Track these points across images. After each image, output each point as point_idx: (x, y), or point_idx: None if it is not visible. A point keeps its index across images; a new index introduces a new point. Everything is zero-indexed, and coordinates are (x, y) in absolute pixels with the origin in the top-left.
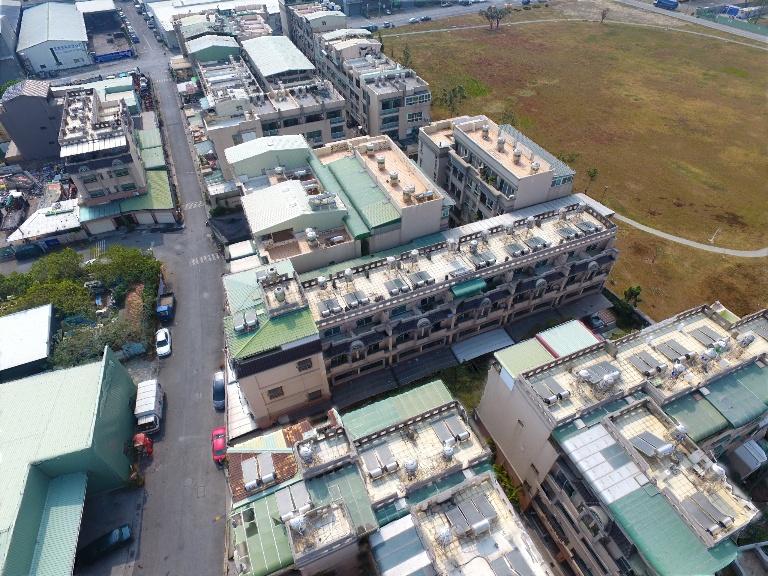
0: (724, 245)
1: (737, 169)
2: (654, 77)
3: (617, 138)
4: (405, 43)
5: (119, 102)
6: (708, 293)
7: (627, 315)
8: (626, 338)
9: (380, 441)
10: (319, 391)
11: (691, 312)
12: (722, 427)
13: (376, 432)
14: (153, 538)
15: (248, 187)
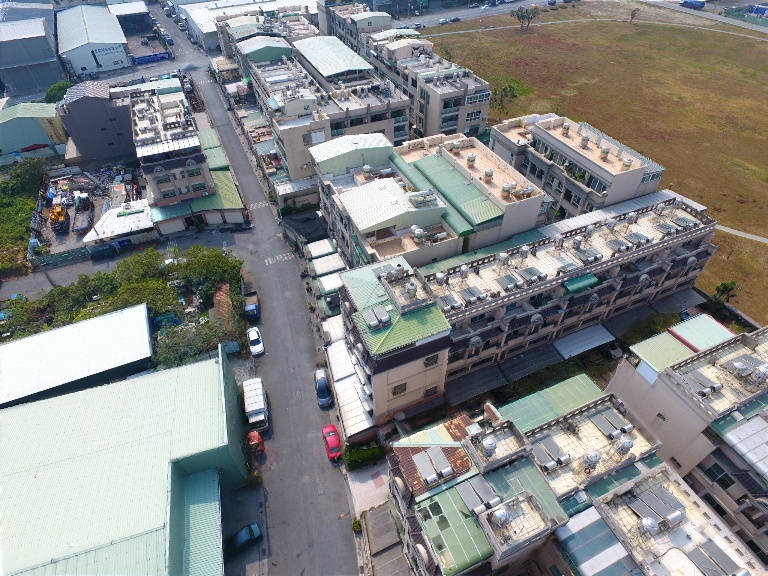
0: None
1: None
2: (693, 76)
3: (668, 136)
4: (440, 44)
5: (179, 103)
6: None
7: (717, 310)
8: (762, 331)
9: (543, 435)
10: (435, 387)
11: None
12: None
13: (541, 425)
14: (281, 536)
15: (334, 185)
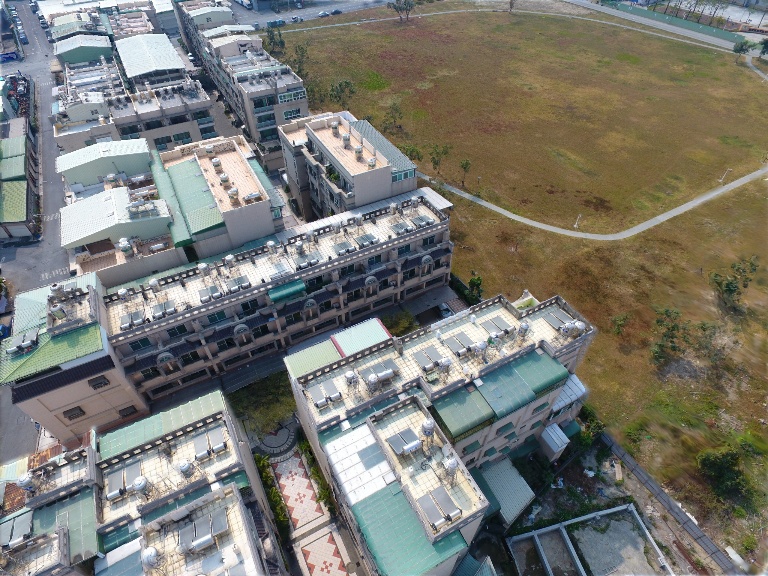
0: (587, 230)
1: (612, 154)
2: (551, 66)
3: (504, 128)
4: (310, 38)
5: None
6: (563, 278)
7: None
8: (415, 334)
9: (134, 460)
10: (132, 407)
11: (487, 303)
12: (488, 417)
13: (125, 452)
14: None
15: (83, 196)
